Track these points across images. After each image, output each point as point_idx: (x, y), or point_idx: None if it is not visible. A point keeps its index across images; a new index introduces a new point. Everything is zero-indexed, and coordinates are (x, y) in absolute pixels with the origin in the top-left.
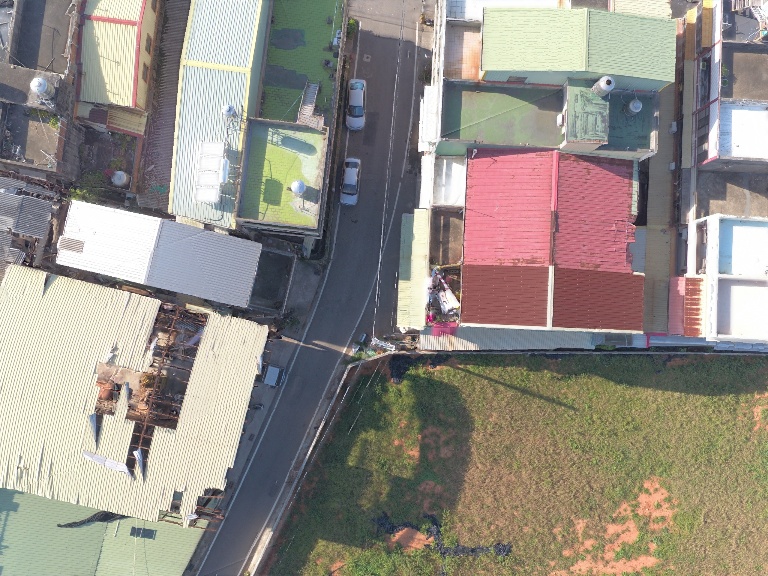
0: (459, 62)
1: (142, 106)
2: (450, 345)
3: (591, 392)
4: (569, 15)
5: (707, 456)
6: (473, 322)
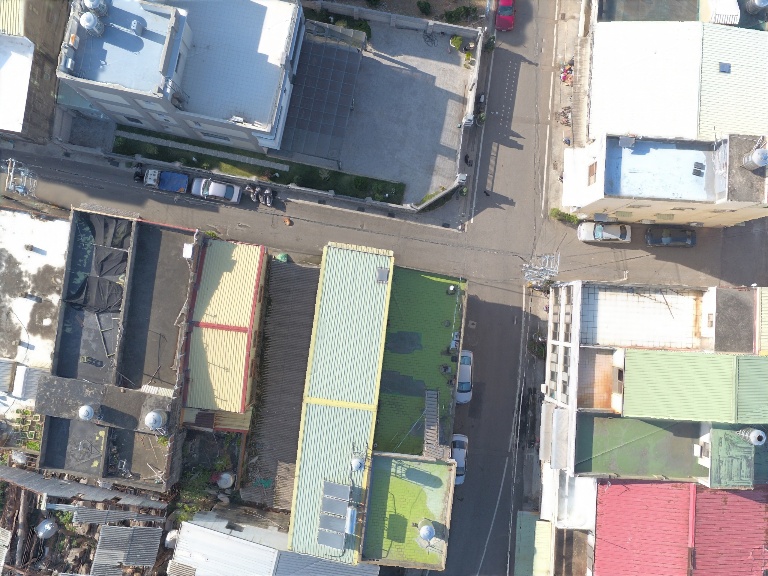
0: (591, 386)
1: (248, 402)
2: None
3: None
4: (716, 361)
5: None
6: None
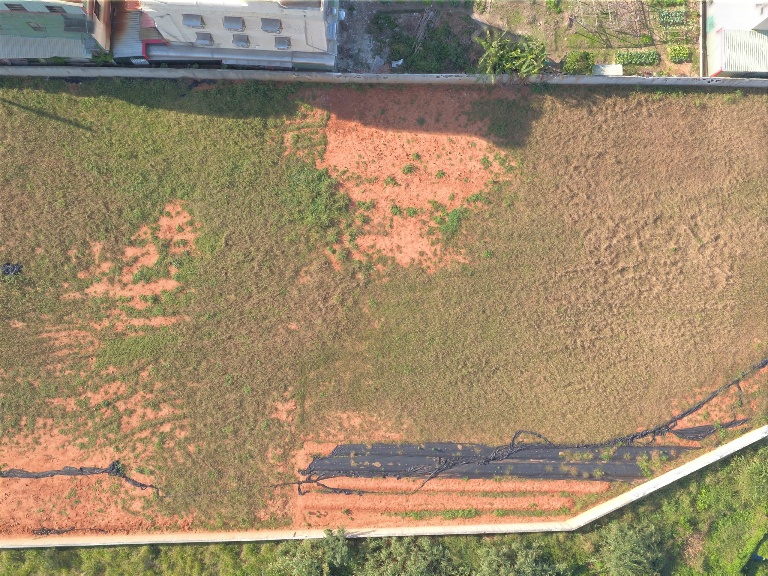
0: None
1: None
2: None
3: (110, 115)
4: None
5: (230, 178)
6: None
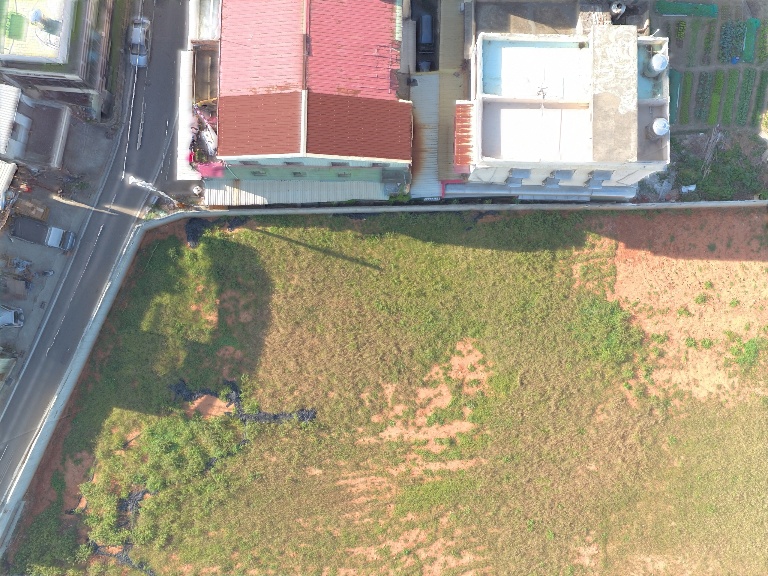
0: None
1: None
2: (237, 199)
3: (397, 251)
4: None
5: (522, 315)
6: (229, 155)
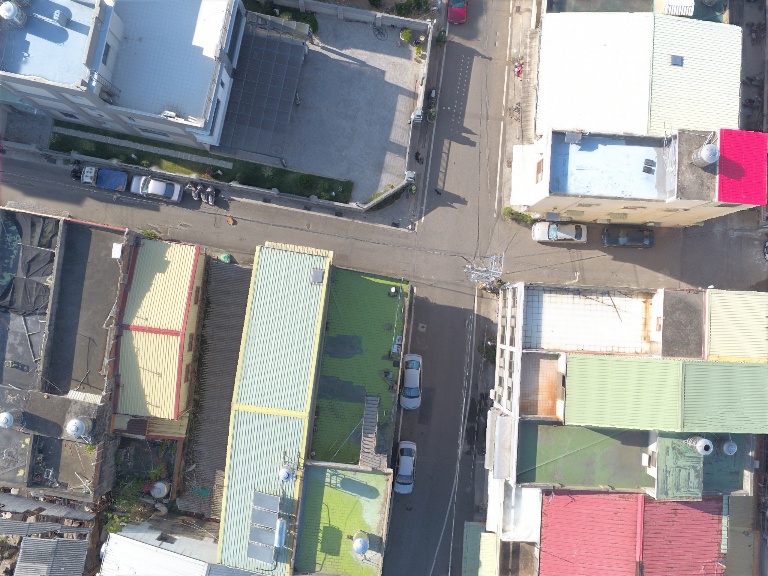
0: (535, 393)
1: (183, 408)
2: None
3: None
4: (662, 367)
5: None
6: None
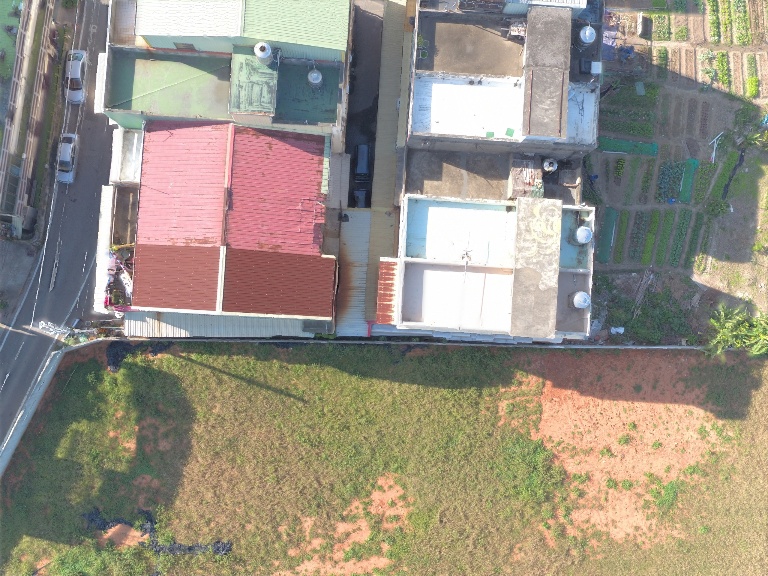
0: (133, 28)
1: None
2: (158, 331)
3: (323, 383)
4: None
5: (445, 452)
6: (144, 305)
